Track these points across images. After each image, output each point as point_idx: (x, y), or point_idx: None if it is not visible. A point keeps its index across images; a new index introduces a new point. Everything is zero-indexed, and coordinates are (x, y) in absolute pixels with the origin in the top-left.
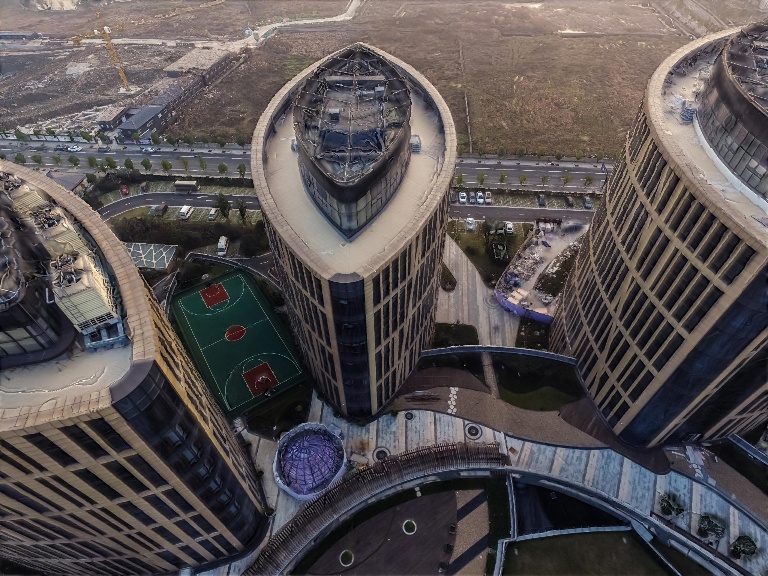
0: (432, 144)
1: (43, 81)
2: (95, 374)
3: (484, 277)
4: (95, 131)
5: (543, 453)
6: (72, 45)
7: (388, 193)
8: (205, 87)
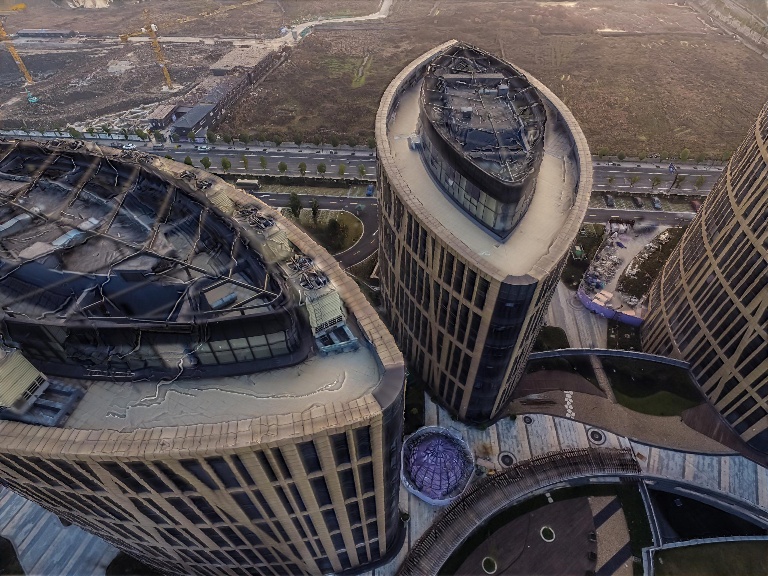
0: (553, 143)
1: (86, 79)
2: (338, 379)
3: (564, 278)
4: (147, 129)
5: (672, 459)
6: (110, 43)
7: None
8: (250, 85)
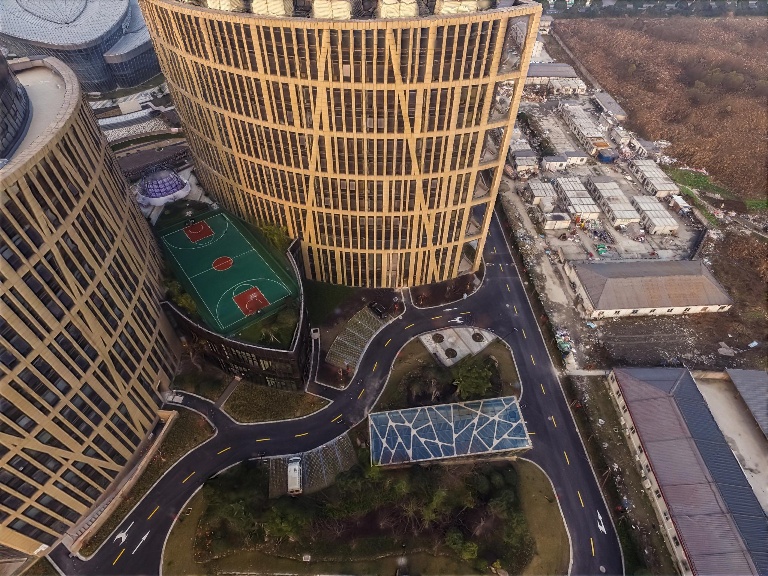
0: None
1: None
2: None
3: None
4: None
5: None
6: None
7: None
8: None
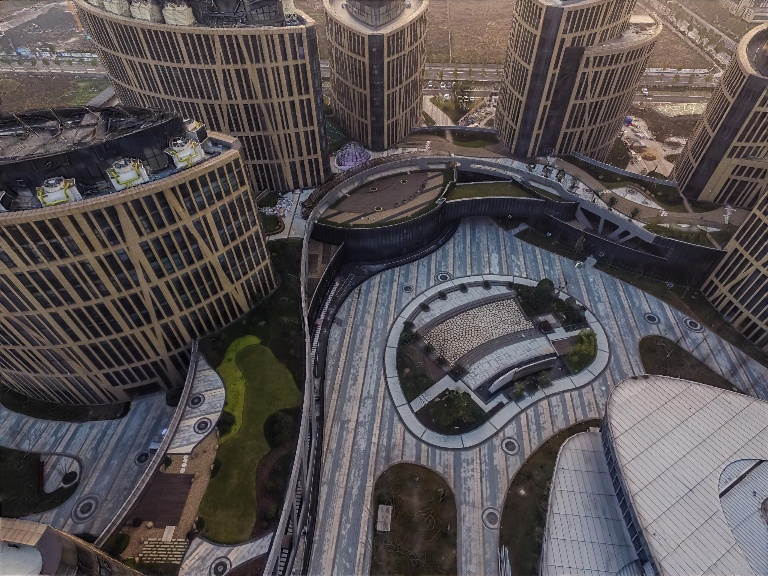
0: (417, 4)
1: None
2: None
3: (453, 120)
4: None
5: None
6: None
7: (394, 15)
8: None
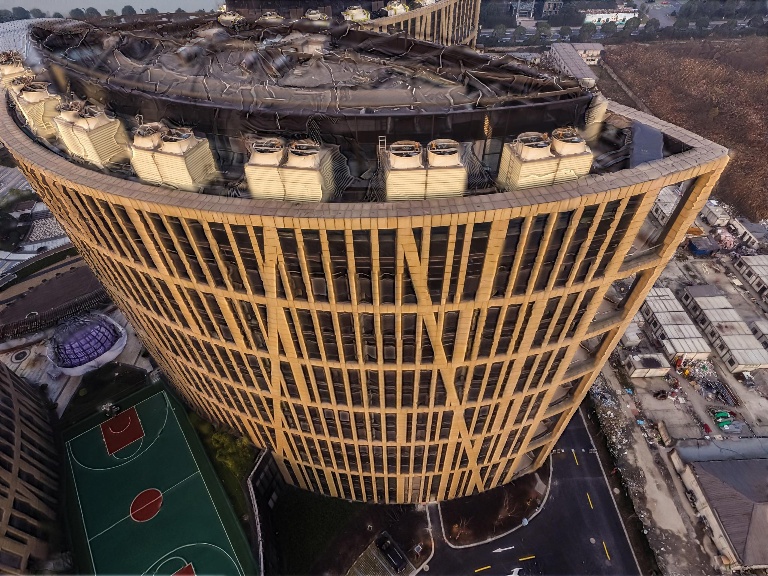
0: None
1: None
2: None
3: None
4: None
5: None
6: None
7: None
8: None
